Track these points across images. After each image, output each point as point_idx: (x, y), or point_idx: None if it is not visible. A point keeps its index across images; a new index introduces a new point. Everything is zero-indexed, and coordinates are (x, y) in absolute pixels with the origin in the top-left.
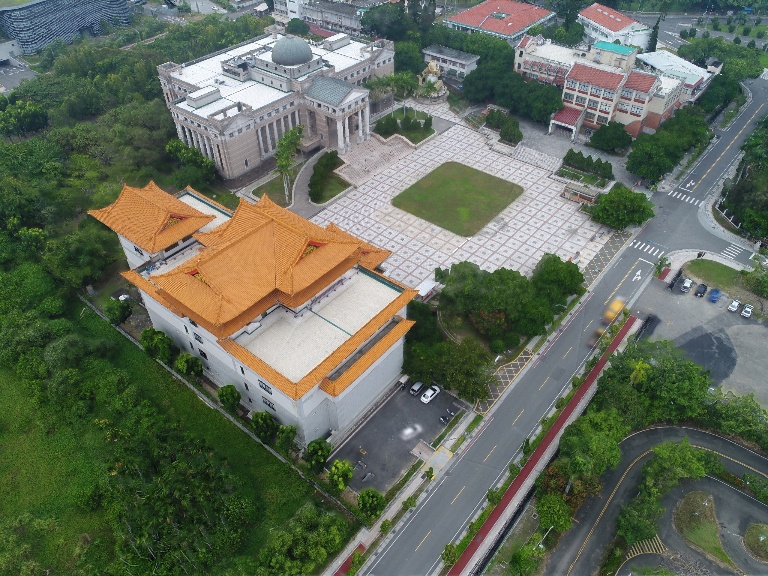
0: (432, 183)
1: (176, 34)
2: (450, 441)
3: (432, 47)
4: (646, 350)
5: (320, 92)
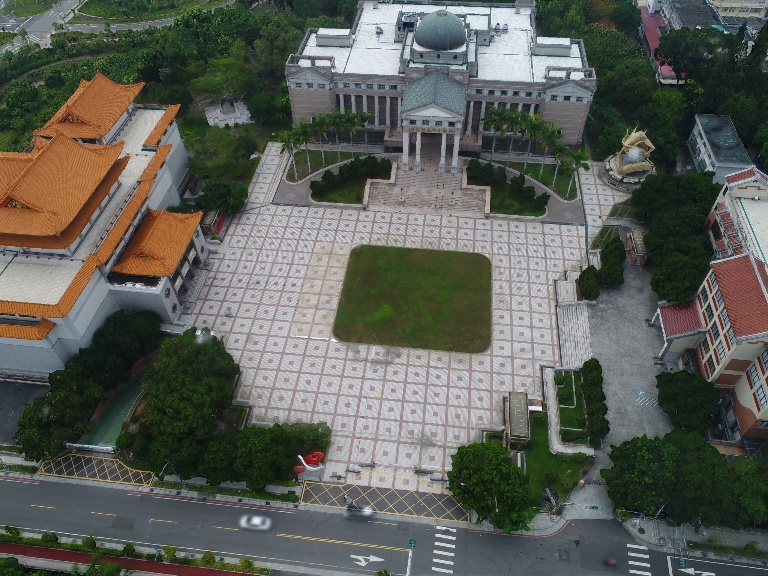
0: (422, 261)
1: None
2: None
3: (718, 118)
4: None
5: (415, 89)
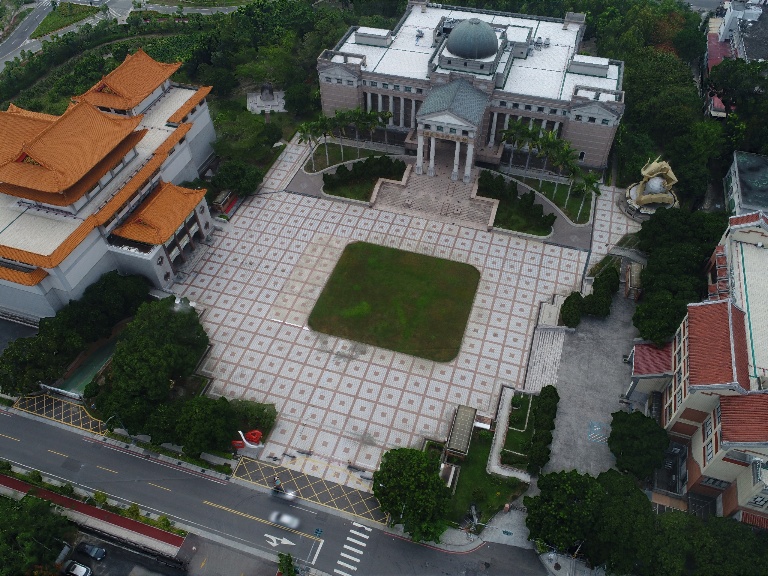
0: (412, 265)
1: None
2: None
3: (759, 157)
4: (3, 518)
5: (436, 95)
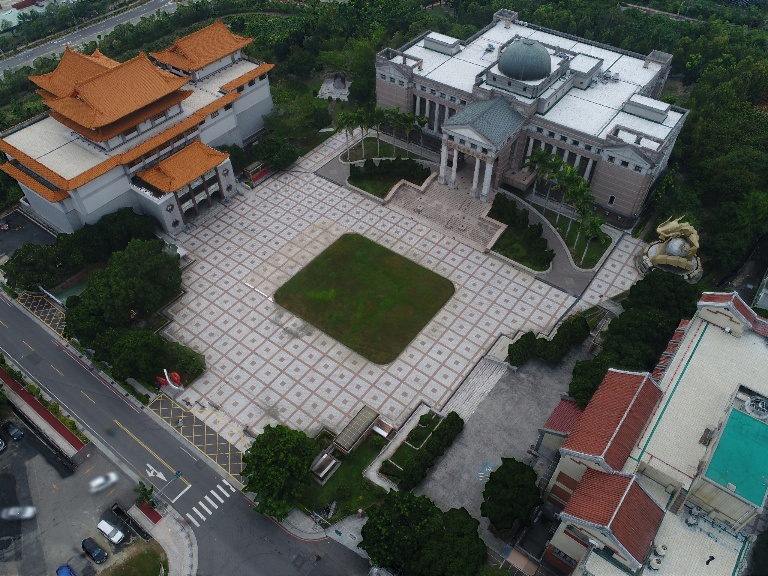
0: (394, 267)
1: (699, 26)
2: (3, 277)
3: None
4: None
5: (471, 108)
